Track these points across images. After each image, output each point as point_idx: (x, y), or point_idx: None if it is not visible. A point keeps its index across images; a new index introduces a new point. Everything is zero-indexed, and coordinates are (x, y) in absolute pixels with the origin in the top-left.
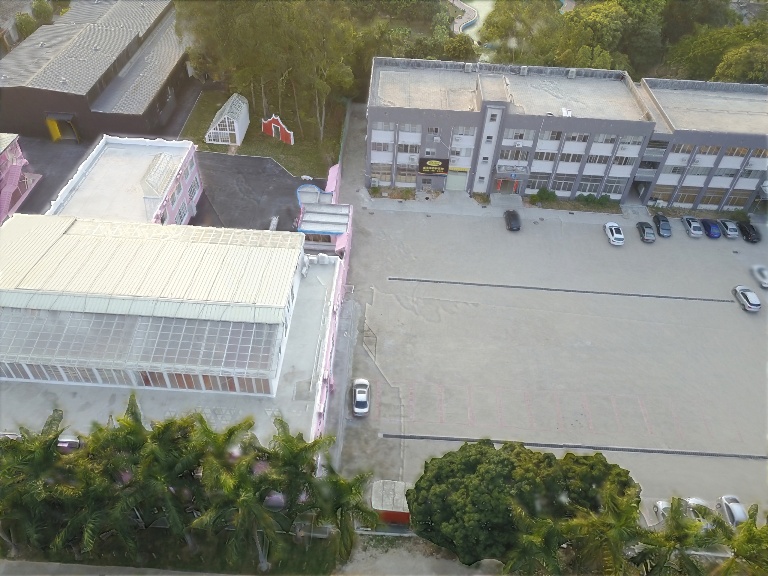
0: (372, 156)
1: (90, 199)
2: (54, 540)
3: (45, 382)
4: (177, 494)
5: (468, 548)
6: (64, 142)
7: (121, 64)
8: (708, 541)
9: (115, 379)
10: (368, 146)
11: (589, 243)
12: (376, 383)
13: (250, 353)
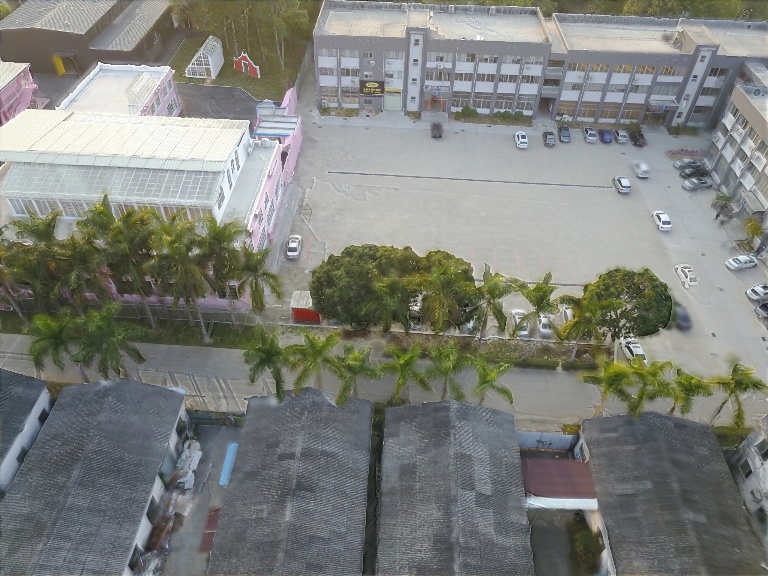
0: (320, 80)
1: (86, 107)
2: (53, 291)
3: None
4: (138, 266)
5: (346, 309)
6: (68, 76)
7: (115, 14)
8: (507, 290)
9: None
10: (316, 71)
11: (499, 147)
12: (308, 239)
13: (198, 190)
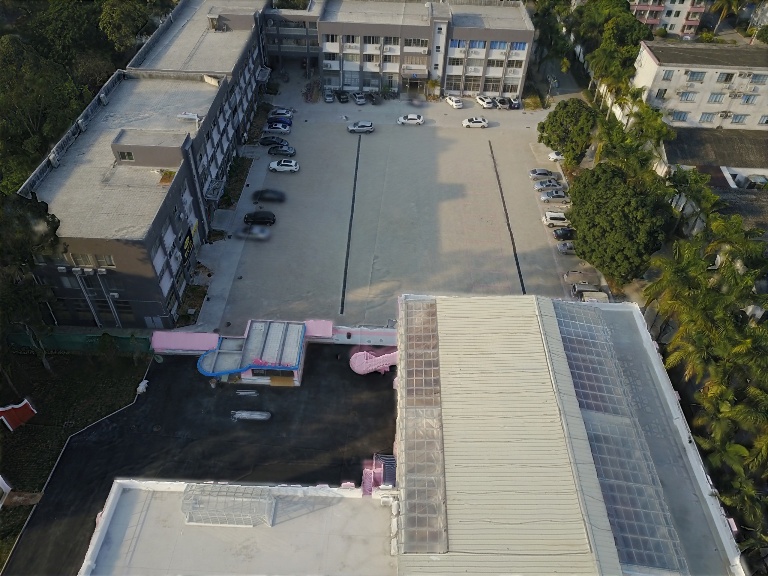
0: (162, 291)
1: None
2: None
3: None
4: None
5: None
6: None
7: None
8: None
9: None
10: (157, 284)
11: (292, 183)
12: None
13: (585, 323)
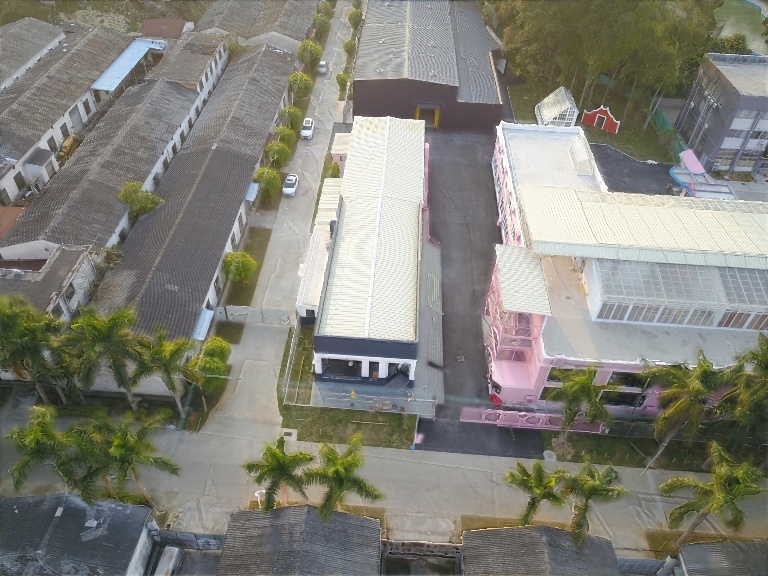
0: (723, 142)
1: (533, 176)
2: None
3: (635, 323)
4: None
5: None
6: None
7: None
8: None
9: (701, 320)
10: (724, 133)
11: None
12: None
13: None
